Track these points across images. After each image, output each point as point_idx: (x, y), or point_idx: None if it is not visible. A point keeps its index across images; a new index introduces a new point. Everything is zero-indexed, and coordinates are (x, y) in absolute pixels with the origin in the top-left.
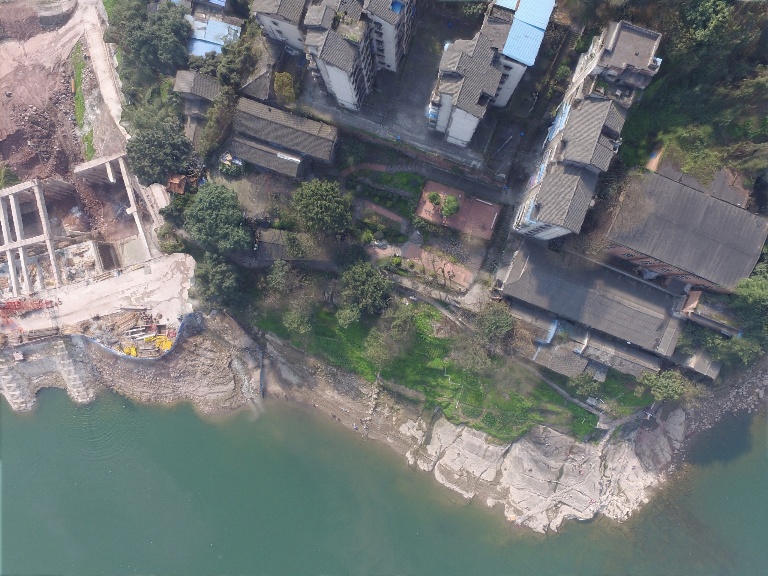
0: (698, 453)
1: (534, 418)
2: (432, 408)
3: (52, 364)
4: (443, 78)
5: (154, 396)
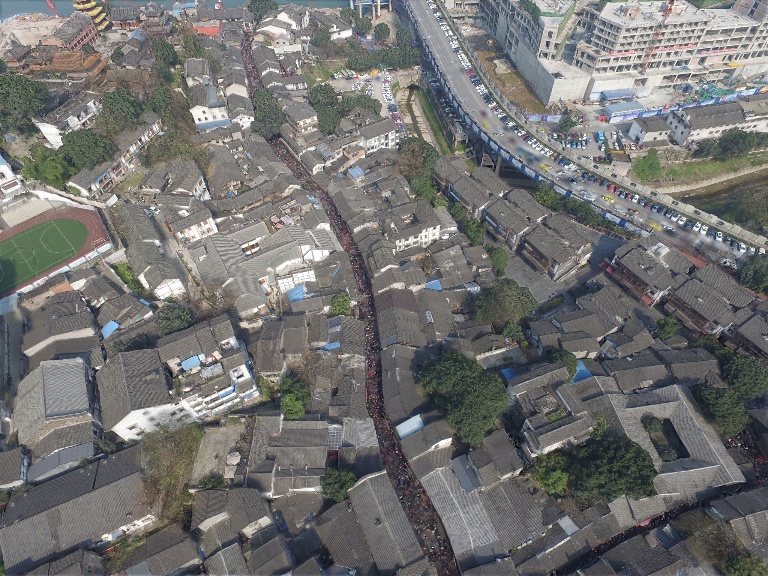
0: None
1: None
2: None
3: None
4: None
5: None
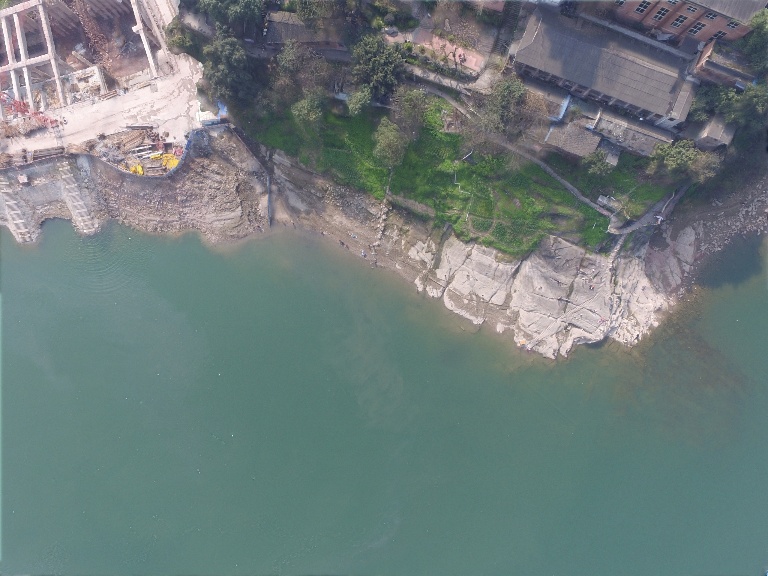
0: (708, 276)
1: (545, 226)
2: (441, 226)
3: (57, 191)
4: None
5: (160, 225)
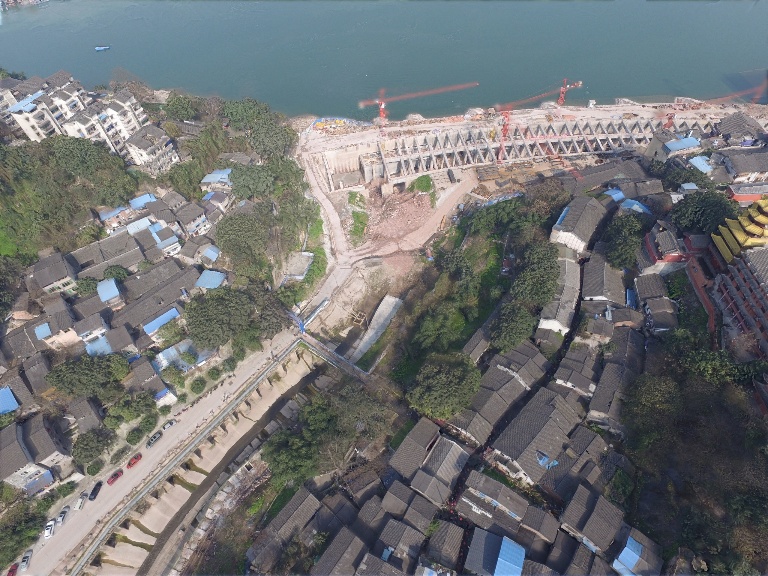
0: None
1: None
2: None
3: None
4: (78, 90)
5: None
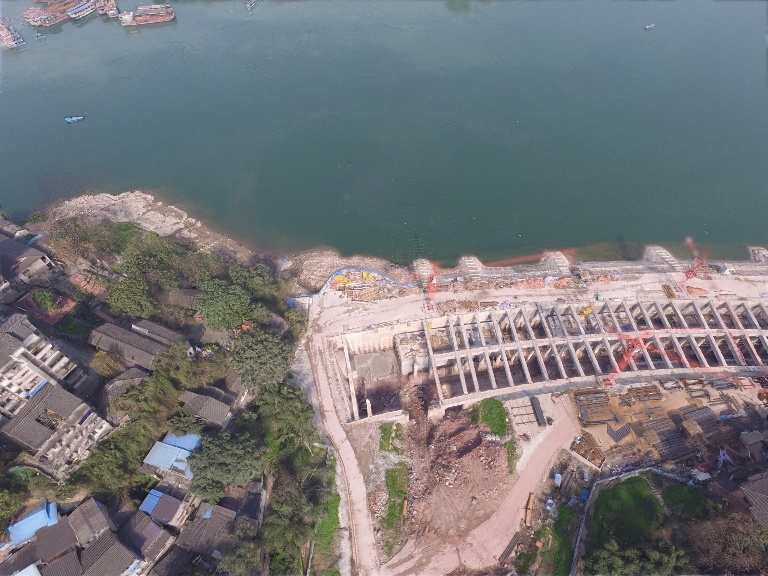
0: None
1: None
2: None
3: None
4: None
5: None
